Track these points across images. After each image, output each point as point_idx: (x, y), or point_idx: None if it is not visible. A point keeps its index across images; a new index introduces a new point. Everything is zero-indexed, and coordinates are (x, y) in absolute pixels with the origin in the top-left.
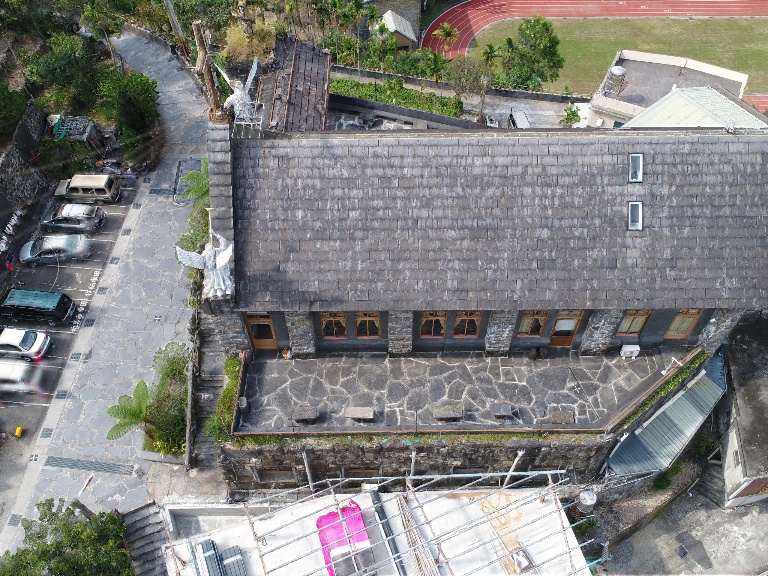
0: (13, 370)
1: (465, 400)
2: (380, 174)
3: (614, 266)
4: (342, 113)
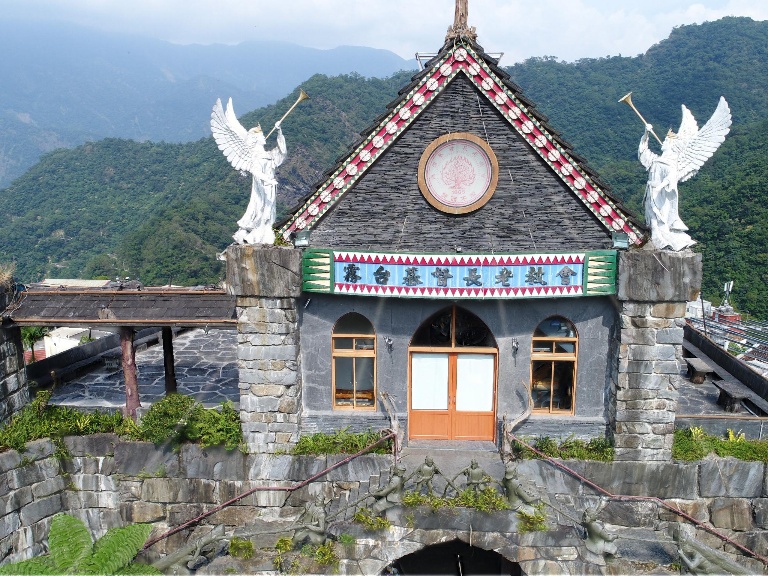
0: None
1: None
2: None
3: None
4: (67, 383)
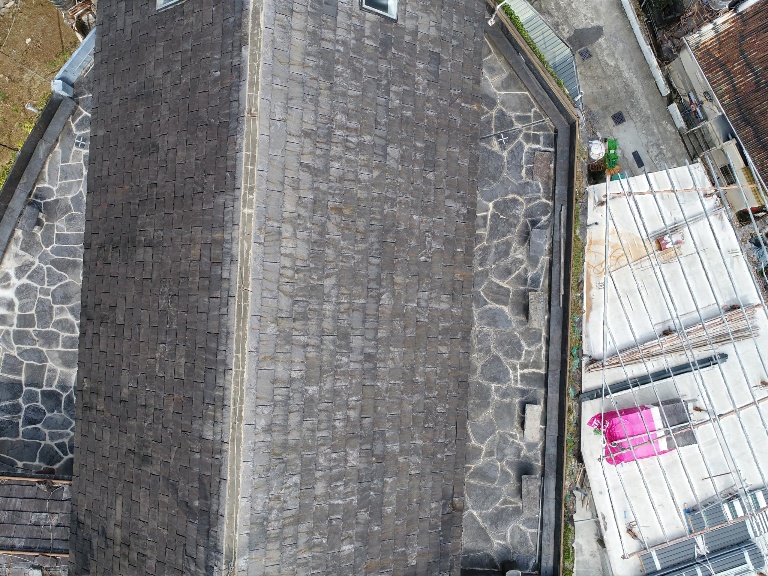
0: None
1: (512, 285)
2: (298, 419)
3: (438, 58)
4: None
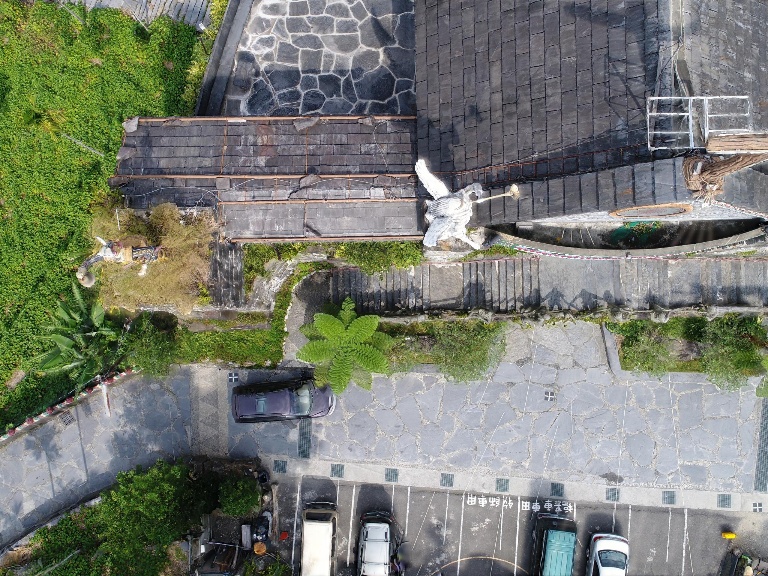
0: (637, 572)
1: None
2: None
3: None
4: None
